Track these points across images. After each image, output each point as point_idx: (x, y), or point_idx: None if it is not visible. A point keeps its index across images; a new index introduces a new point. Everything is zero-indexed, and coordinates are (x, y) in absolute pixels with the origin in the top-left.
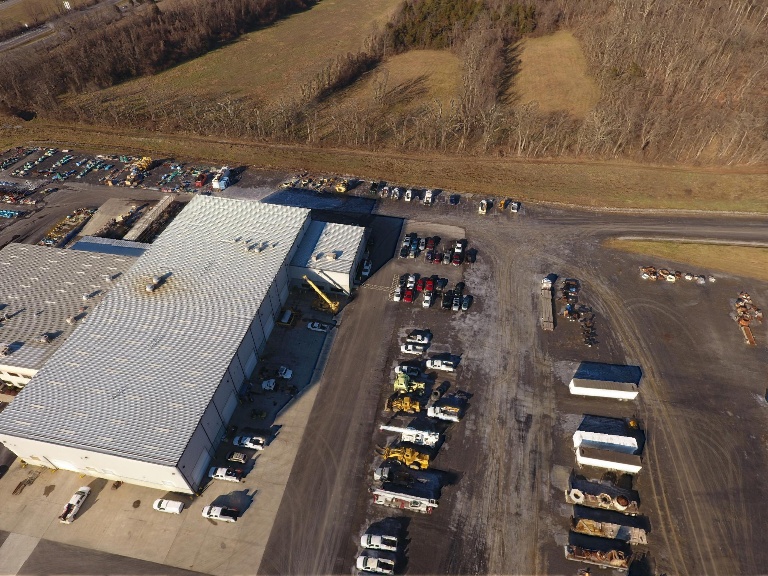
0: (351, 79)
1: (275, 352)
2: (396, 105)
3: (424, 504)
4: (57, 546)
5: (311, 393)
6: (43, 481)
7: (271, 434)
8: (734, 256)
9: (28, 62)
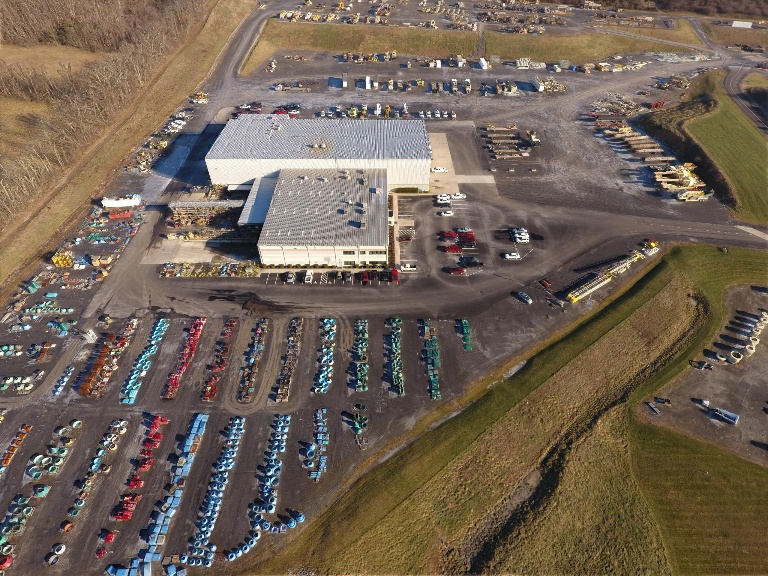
0: None
1: None
2: None
3: None
4: None
5: None
6: None
7: None
8: (259, 53)
9: None
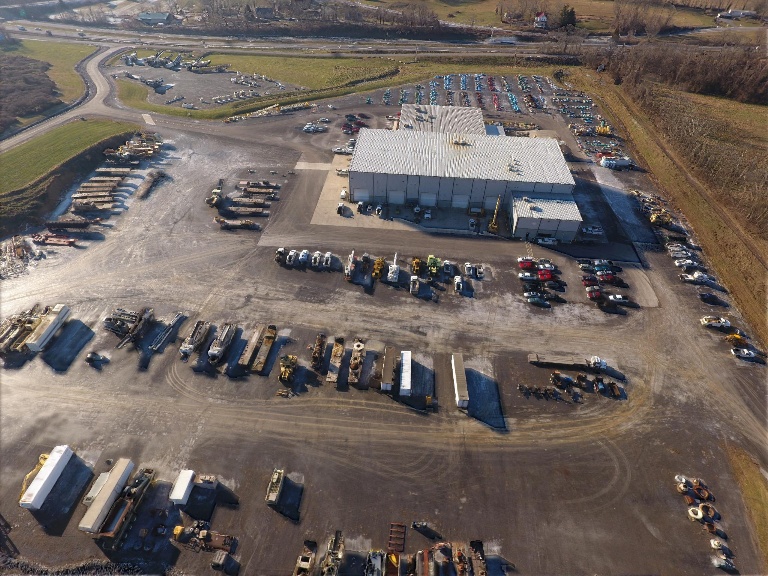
0: None
1: (445, 211)
2: None
3: None
4: (326, 174)
5: (418, 229)
6: None
7: (387, 218)
8: None
9: (664, 53)
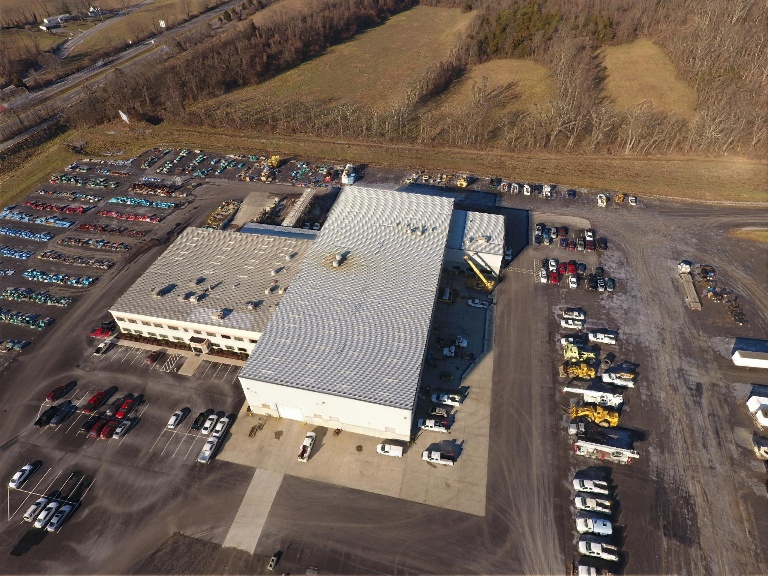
0: (445, 86)
1: (444, 325)
2: (493, 109)
3: (625, 455)
4: (301, 480)
5: (488, 360)
6: (271, 427)
7: (462, 394)
8: None
9: (154, 73)
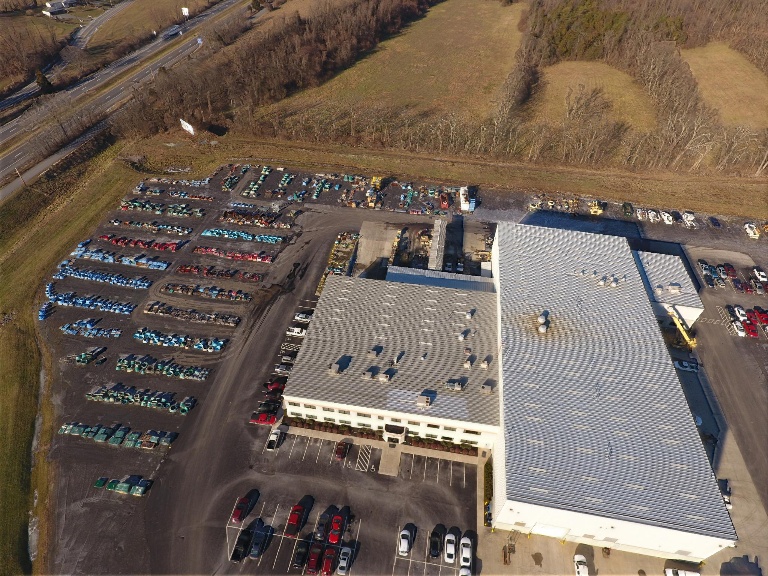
0: None
1: None
2: None
3: None
4: None
5: (730, 442)
6: (524, 548)
7: (724, 490)
8: None
9: (211, 74)
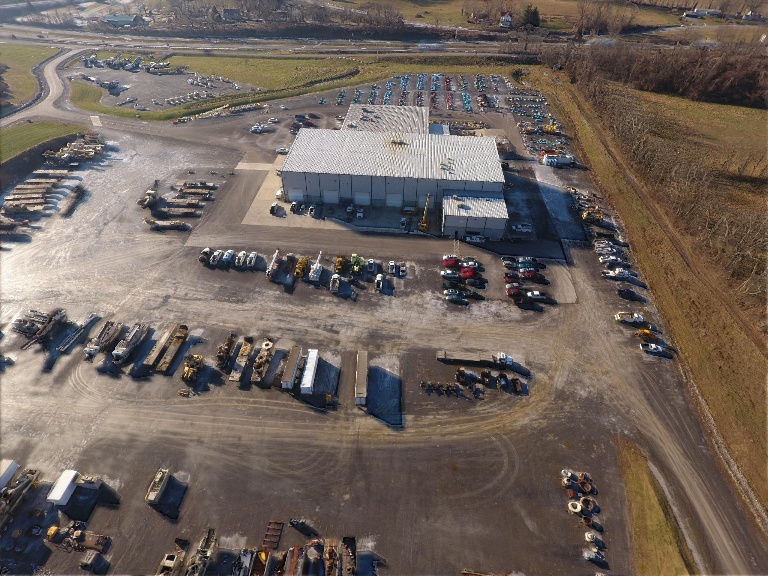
0: None
1: (379, 210)
2: None
3: None
4: (266, 174)
5: (348, 228)
6: None
7: (319, 217)
8: None
9: (619, 51)
